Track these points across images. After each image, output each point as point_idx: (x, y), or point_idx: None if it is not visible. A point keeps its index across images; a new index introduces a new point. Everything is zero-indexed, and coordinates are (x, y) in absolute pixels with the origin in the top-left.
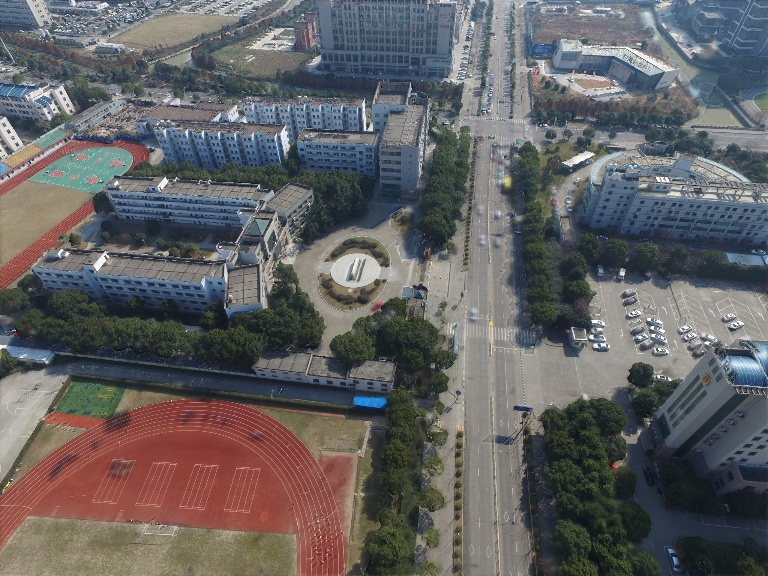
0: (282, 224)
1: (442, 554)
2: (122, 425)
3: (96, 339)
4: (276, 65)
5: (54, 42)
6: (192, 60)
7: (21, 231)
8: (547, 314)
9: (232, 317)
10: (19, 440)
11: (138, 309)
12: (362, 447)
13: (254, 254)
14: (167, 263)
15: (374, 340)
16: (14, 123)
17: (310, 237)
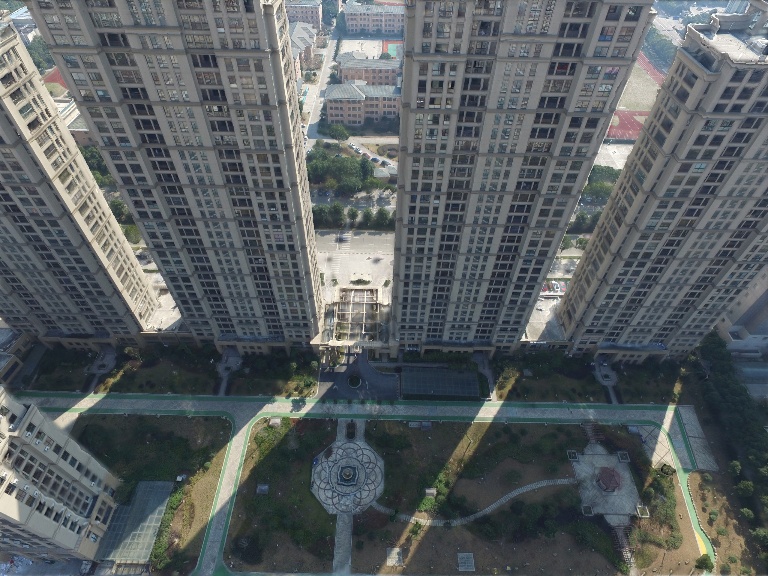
0: None
1: None
2: None
3: None
4: None
5: None
6: None
7: None
8: (674, 4)
9: None
10: None
11: None
12: None
13: None
14: None
15: None
16: None
17: None
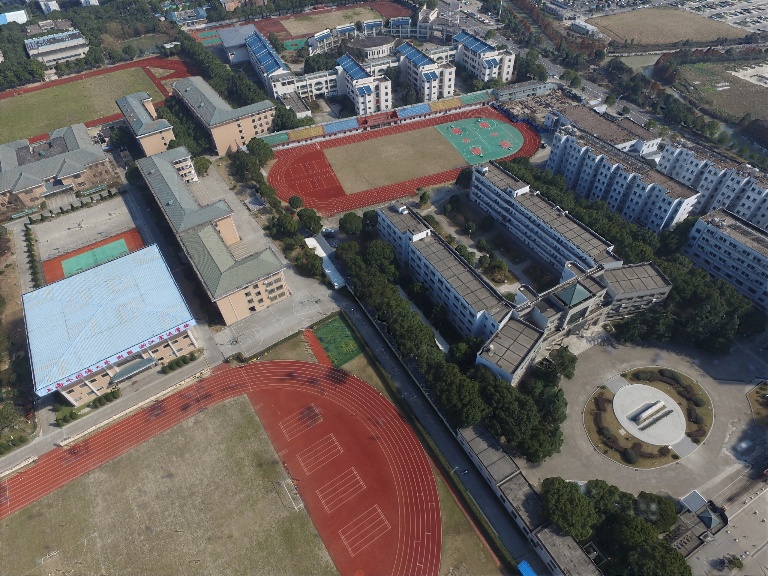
0: (605, 303)
1: None
2: (338, 381)
3: (372, 298)
4: (751, 106)
5: (542, 8)
6: (654, 66)
7: (400, 168)
8: None
9: (478, 367)
10: (282, 333)
11: (418, 294)
12: None
13: (547, 320)
14: (466, 272)
15: (600, 520)
16: (460, 73)
17: (625, 337)
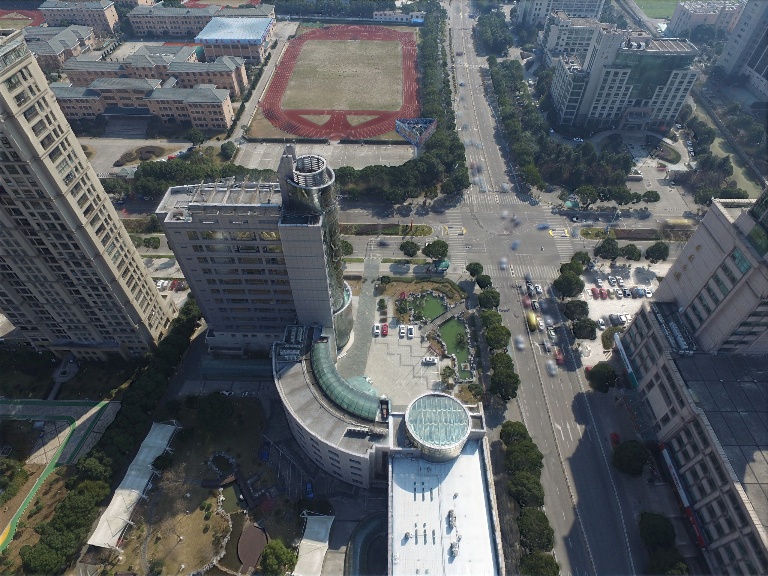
0: None
1: (446, 42)
2: (328, 28)
3: (311, 6)
4: None
5: None
6: None
7: None
8: (482, 3)
9: None
10: None
11: None
12: (416, 30)
13: None
14: None
15: None
16: None
17: None
